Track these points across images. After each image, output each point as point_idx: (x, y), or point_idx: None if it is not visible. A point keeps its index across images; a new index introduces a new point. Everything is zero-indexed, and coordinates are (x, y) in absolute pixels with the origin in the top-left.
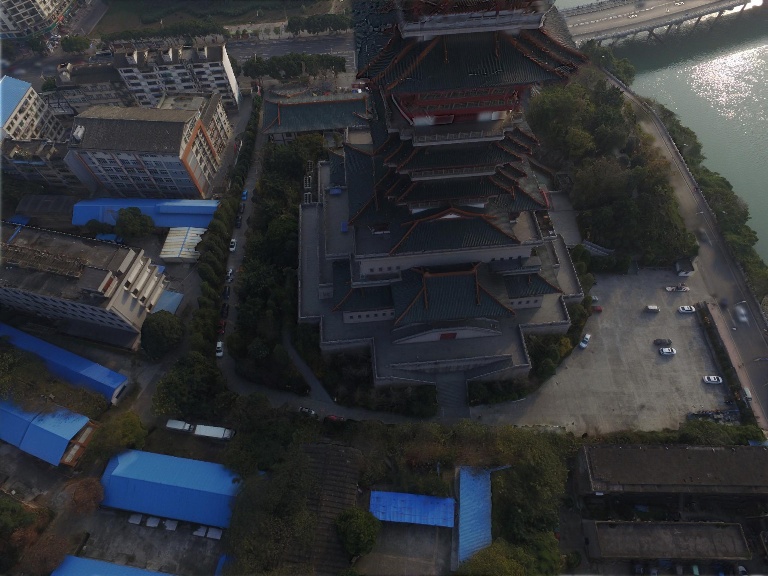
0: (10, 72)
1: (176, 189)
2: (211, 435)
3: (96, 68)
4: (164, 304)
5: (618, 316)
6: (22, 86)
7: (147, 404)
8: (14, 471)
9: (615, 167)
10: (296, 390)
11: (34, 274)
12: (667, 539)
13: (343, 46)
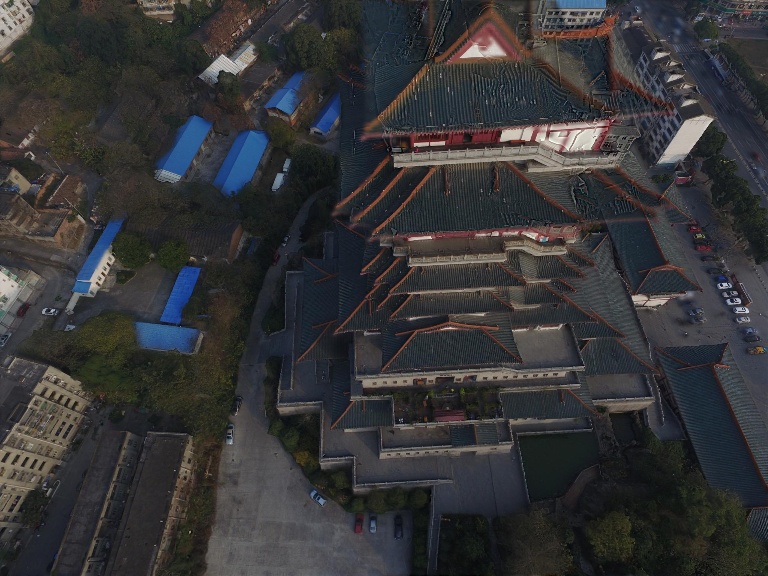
0: (654, 7)
1: None
2: (275, 182)
3: (644, 40)
4: None
5: (348, 555)
6: (599, 3)
7: None
8: None
9: (551, 573)
10: (300, 229)
11: None
12: (94, 496)
13: None
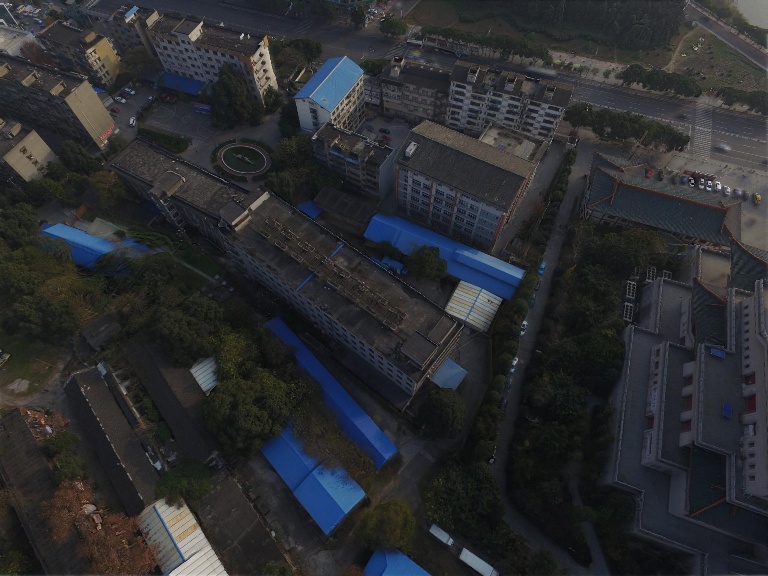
0: (324, 37)
1: (470, 232)
2: (477, 569)
3: (427, 71)
4: (446, 375)
5: None
6: (356, 71)
7: (407, 486)
8: (275, 506)
9: None
10: (581, 560)
11: (350, 306)
12: None
13: (678, 115)
